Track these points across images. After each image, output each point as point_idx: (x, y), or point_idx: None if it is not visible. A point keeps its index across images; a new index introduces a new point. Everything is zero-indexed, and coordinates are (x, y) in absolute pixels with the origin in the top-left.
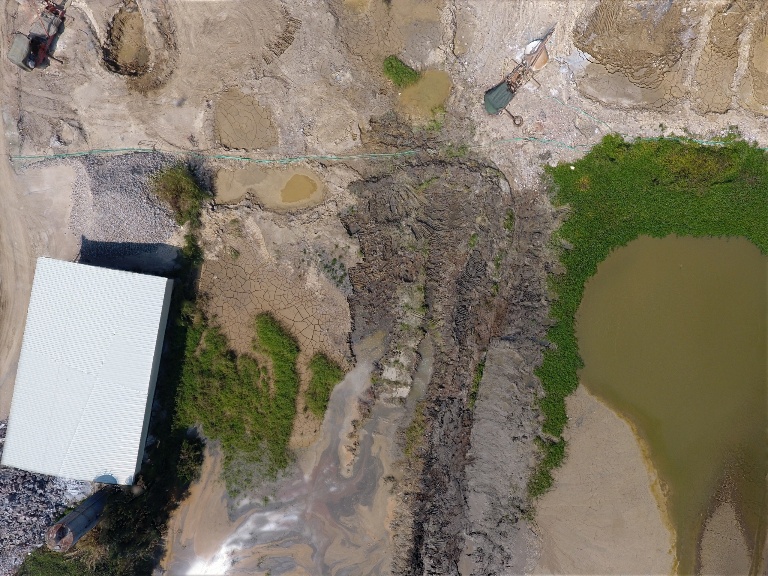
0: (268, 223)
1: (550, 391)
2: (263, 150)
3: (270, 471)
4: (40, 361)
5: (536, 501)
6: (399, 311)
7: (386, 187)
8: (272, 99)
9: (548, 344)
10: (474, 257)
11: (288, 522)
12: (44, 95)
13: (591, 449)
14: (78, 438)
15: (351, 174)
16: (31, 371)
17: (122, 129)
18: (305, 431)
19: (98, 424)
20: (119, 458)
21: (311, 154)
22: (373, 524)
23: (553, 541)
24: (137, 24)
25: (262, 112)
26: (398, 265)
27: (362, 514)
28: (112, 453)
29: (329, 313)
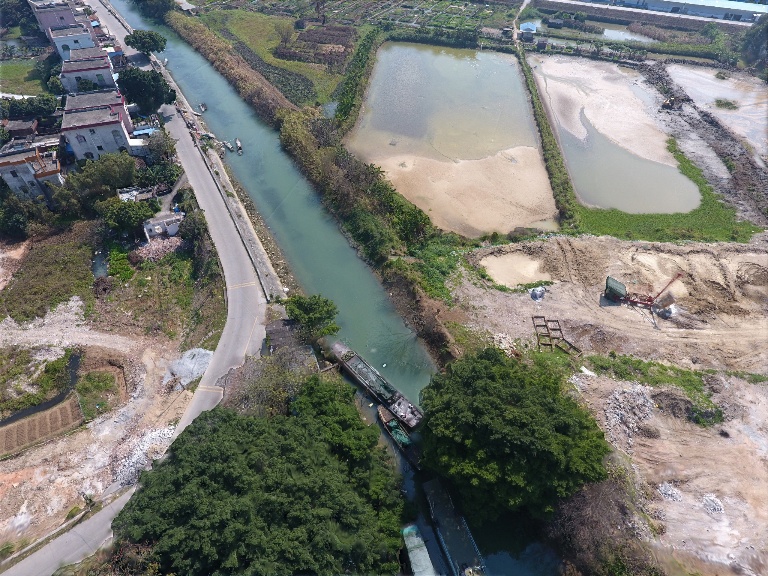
0: None
1: None
2: None
3: None
4: None
5: None
6: None
7: None
8: None
9: None
10: None
11: None
12: None
13: None
14: None
15: None
16: None
17: None
18: None
19: None
20: None
21: None
22: None
23: None
24: None
25: None
26: None
27: None
28: None
29: None
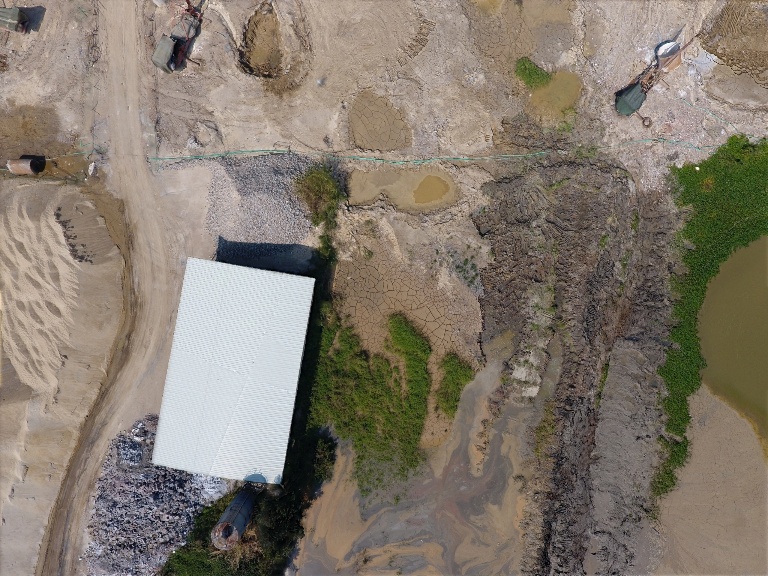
0: (401, 224)
1: (673, 391)
2: (397, 151)
3: (401, 470)
4: (191, 361)
5: (660, 500)
6: (529, 311)
7: (518, 188)
8: (407, 101)
9: (670, 344)
10: (604, 257)
11: (419, 521)
12: (181, 97)
13: (714, 448)
14: (229, 437)
15: (484, 175)
16: (182, 371)
17: (258, 130)
18: (436, 430)
19: (248, 423)
20: (268, 457)
21: (444, 155)
22: (503, 523)
23: (676, 540)
24: (270, 26)
25: (396, 113)
26: (527, 265)
27: (492, 513)
28: (262, 452)
29: (460, 313)
